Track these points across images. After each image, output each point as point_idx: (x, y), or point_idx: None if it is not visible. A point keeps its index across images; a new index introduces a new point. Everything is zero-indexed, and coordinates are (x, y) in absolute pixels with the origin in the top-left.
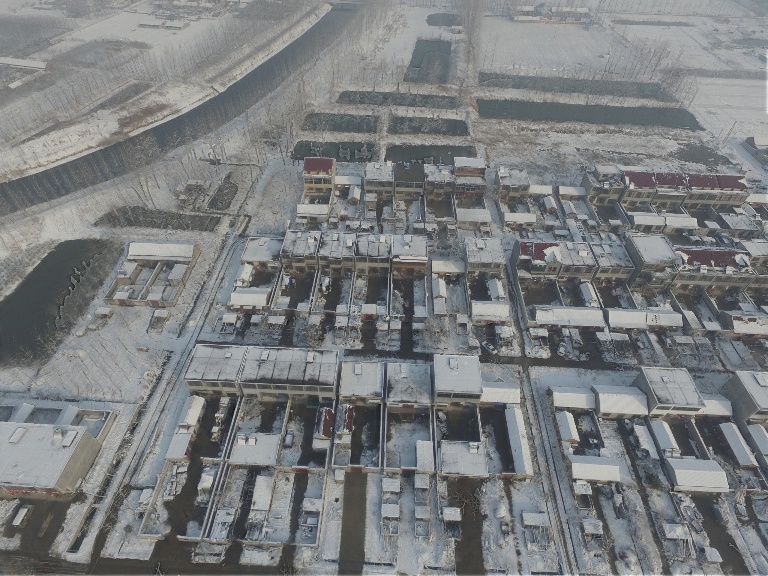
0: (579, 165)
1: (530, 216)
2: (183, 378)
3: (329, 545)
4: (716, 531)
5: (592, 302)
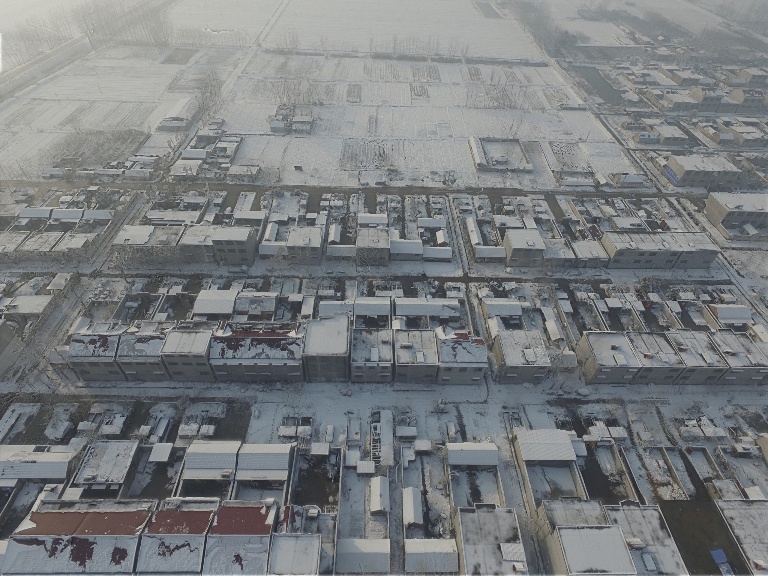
0: None
1: (457, 447)
2: (705, 233)
3: (564, 203)
4: (371, 209)
5: (401, 317)
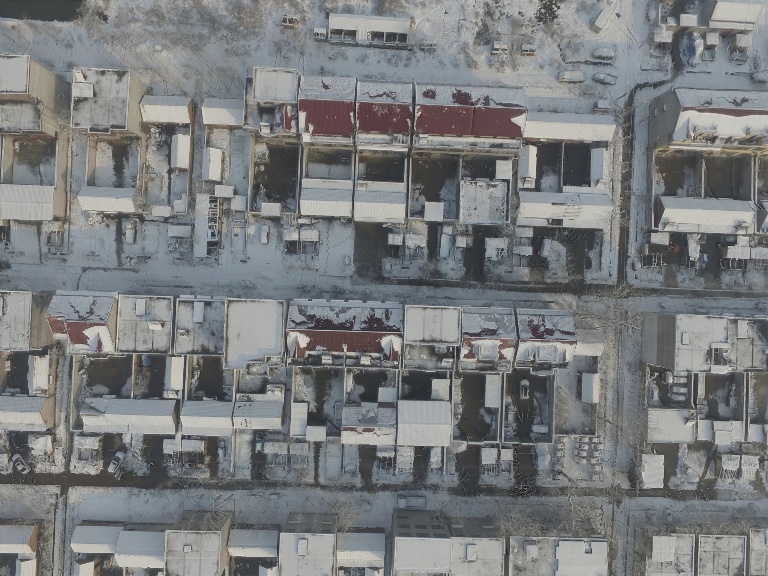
0: (286, 7)
1: (122, 202)
2: None
3: None
4: None
5: (169, 394)
